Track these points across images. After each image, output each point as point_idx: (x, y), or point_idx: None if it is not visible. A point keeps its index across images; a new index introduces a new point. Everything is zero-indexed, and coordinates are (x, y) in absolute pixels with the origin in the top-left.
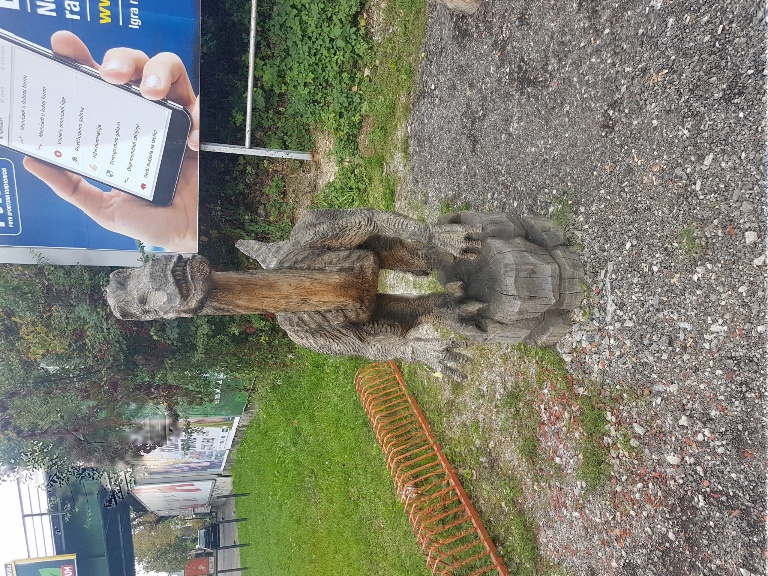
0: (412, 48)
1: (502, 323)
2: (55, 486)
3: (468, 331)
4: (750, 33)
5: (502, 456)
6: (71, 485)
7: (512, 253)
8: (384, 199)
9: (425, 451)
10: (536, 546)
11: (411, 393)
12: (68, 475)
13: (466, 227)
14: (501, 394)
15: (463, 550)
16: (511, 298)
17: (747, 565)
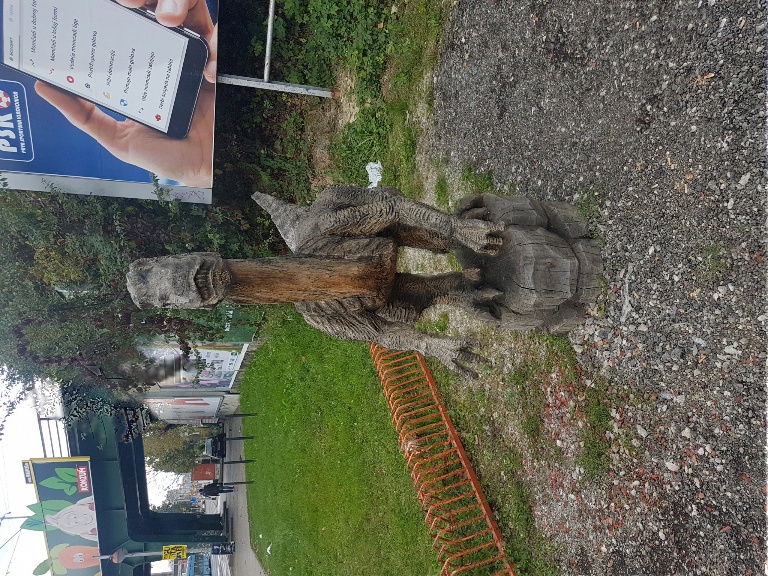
0: None
1: (516, 313)
2: (75, 420)
3: (482, 317)
4: None
5: (505, 428)
6: (90, 420)
7: (532, 245)
8: (404, 150)
9: (430, 410)
10: (531, 517)
11: None
12: (87, 410)
13: (488, 224)
14: (509, 369)
15: (460, 509)
16: (528, 291)
17: None
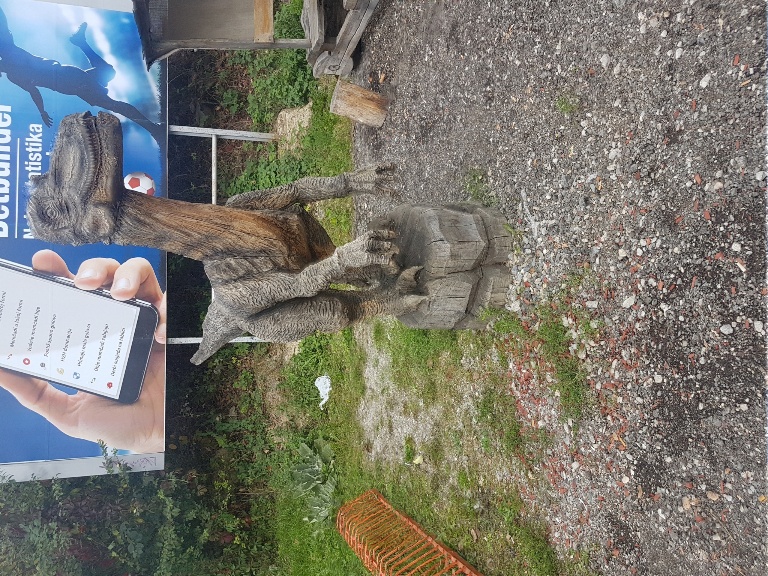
0: None
1: (440, 278)
2: None
3: (410, 298)
4: None
5: (493, 482)
6: None
7: (433, 210)
8: None
9: (419, 546)
10: (551, 551)
11: (398, 505)
12: None
13: None
14: (476, 416)
15: None
16: (440, 243)
17: (724, 320)
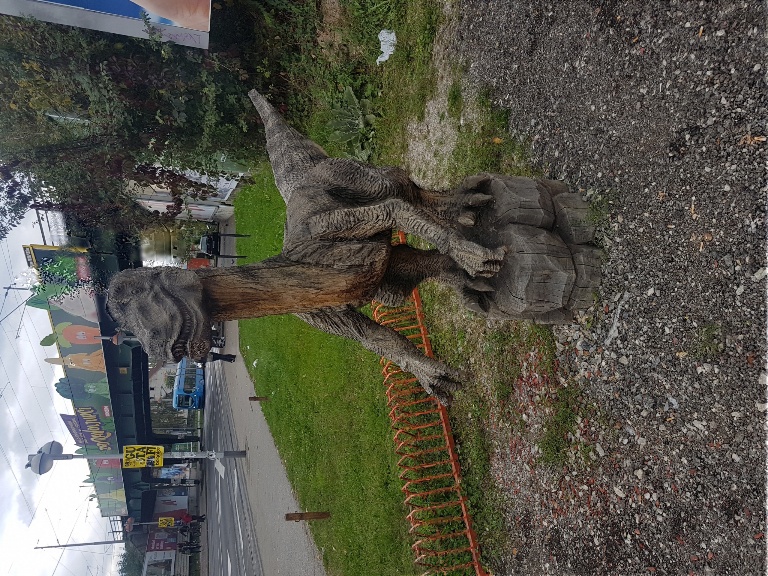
0: None
1: (504, 312)
2: (67, 298)
3: (470, 308)
4: None
5: (479, 376)
6: (82, 298)
7: (532, 256)
8: (422, 35)
9: (412, 331)
10: (488, 464)
11: None
12: (78, 288)
13: (488, 254)
14: (492, 324)
15: None
16: (518, 300)
17: None
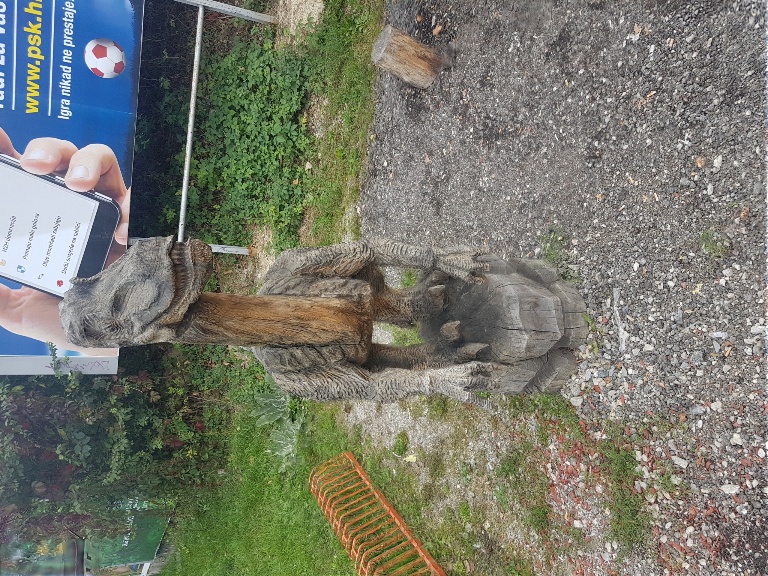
0: (358, 134)
1: (507, 364)
2: None
3: None
4: (744, 38)
5: (502, 535)
6: None
7: (512, 286)
8: None
9: (403, 548)
10: None
11: (377, 486)
12: None
13: (473, 247)
14: (493, 463)
15: None
16: (517, 333)
17: None
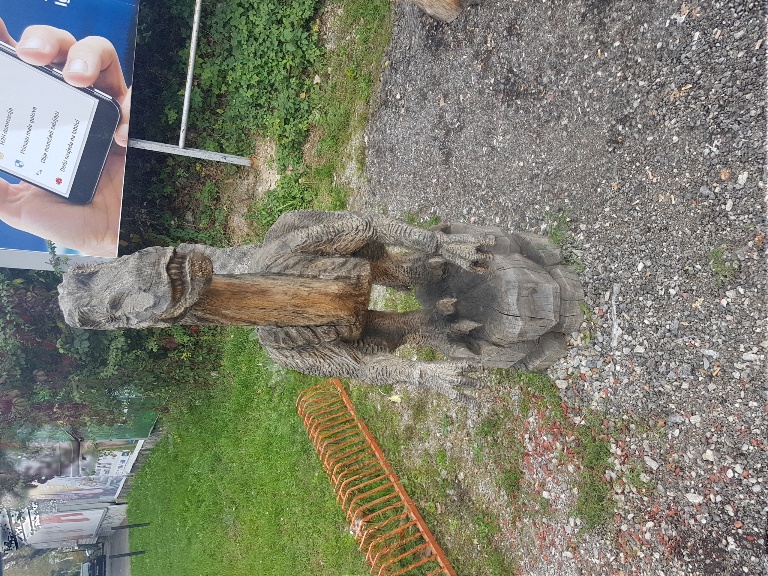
0: (373, 56)
1: (498, 346)
2: None
3: (460, 353)
4: None
5: (474, 488)
6: None
7: (513, 270)
8: None
9: (380, 482)
10: None
11: (361, 418)
12: None
13: (479, 238)
14: (474, 421)
15: None
16: (512, 319)
17: None
